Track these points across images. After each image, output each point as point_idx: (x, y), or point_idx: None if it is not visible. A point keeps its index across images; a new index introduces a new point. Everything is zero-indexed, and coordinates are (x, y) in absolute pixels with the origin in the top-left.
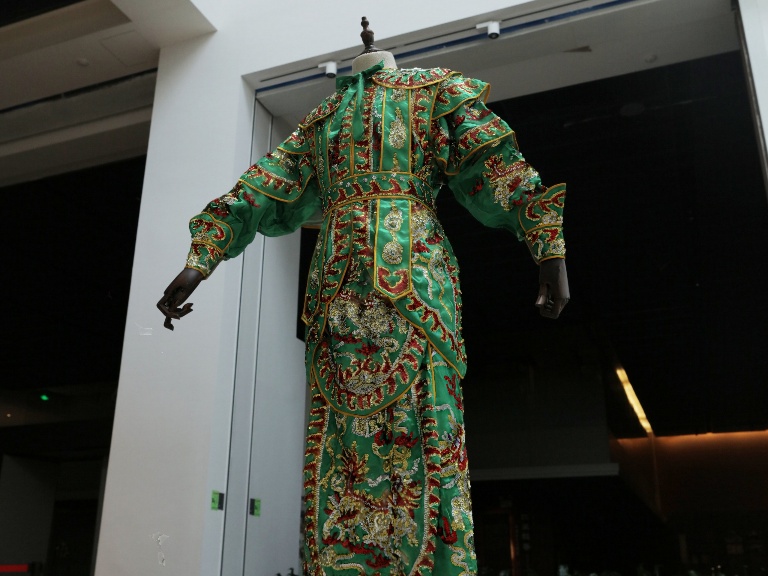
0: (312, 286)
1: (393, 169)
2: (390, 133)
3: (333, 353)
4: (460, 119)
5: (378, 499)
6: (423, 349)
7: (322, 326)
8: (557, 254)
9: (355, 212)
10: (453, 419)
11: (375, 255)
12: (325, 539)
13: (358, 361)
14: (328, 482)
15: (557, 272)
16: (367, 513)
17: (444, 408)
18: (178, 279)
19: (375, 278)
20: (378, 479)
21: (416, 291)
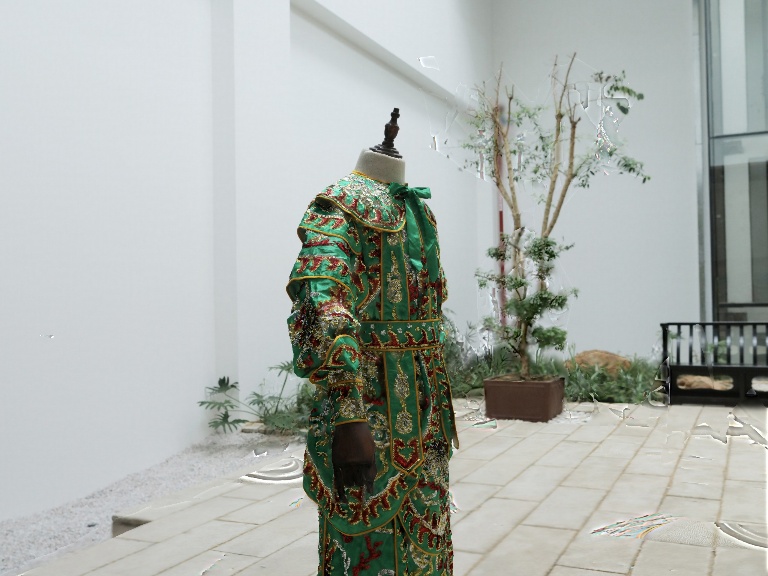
0: (401, 430)
1: None
2: None
3: (415, 498)
4: None
5: None
6: None
7: None
8: None
9: None
10: None
11: None
12: None
13: None
14: None
15: None
16: None
17: None
18: None
19: None
20: None
21: None
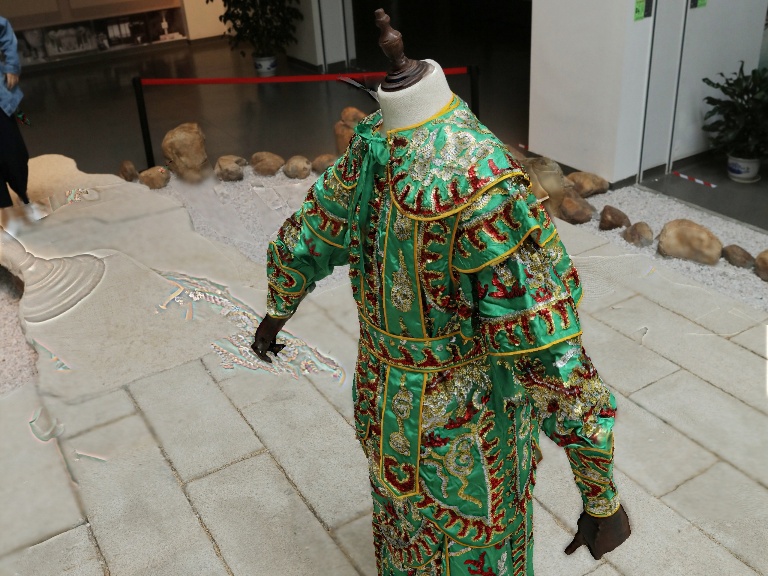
0: None
1: (402, 334)
2: (391, 290)
3: None
4: (480, 292)
5: None
6: (438, 540)
7: None
8: (597, 513)
9: None
10: None
11: (381, 442)
12: None
13: None
14: None
15: (596, 529)
16: None
17: None
18: (260, 329)
19: (381, 468)
20: None
21: (427, 488)
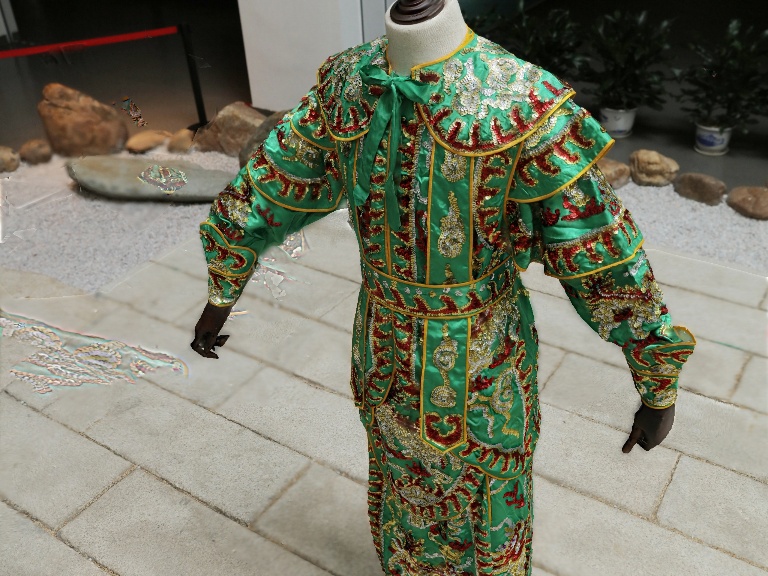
0: None
1: (445, 282)
2: (439, 237)
3: None
4: (551, 218)
5: (435, 567)
6: (479, 483)
7: (370, 420)
8: (663, 406)
9: (396, 332)
10: (510, 527)
11: (421, 401)
12: (390, 570)
13: (409, 478)
14: (390, 529)
15: (658, 421)
16: (425, 573)
17: (500, 527)
18: (205, 323)
19: (422, 428)
20: (434, 555)
21: (473, 434)
